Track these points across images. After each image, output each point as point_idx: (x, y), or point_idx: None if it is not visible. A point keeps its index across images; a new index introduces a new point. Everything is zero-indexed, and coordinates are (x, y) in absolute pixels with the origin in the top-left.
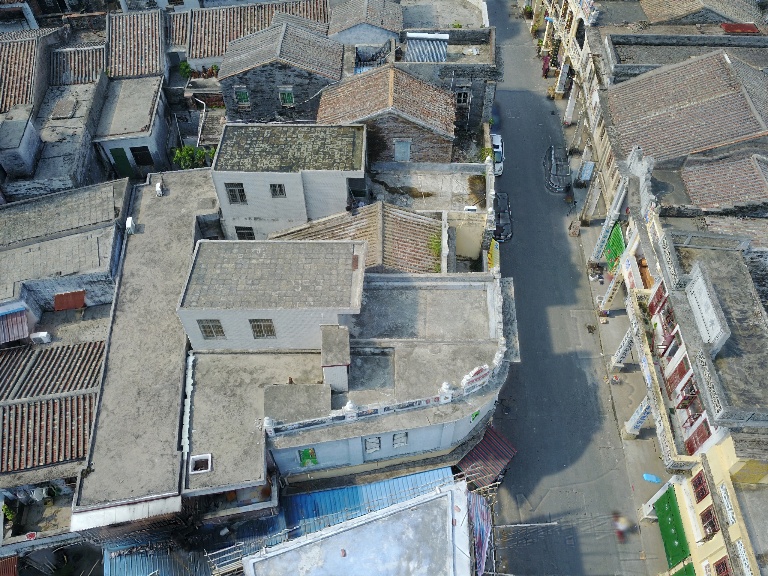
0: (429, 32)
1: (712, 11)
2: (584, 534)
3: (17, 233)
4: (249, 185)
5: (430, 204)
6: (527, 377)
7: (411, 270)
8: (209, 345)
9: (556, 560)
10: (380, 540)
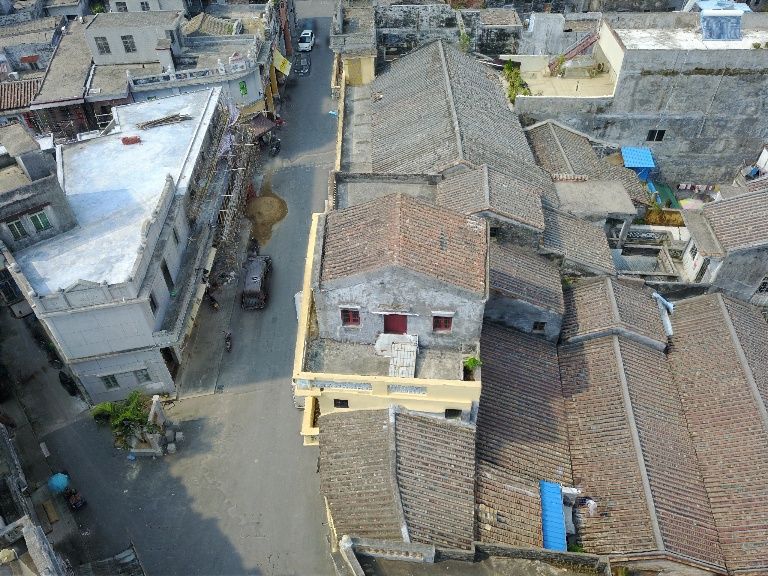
0: None
1: None
2: (316, 168)
3: (0, 33)
4: (129, 3)
5: None
6: (302, 122)
7: (215, 35)
8: (103, 60)
9: (298, 176)
10: (176, 100)
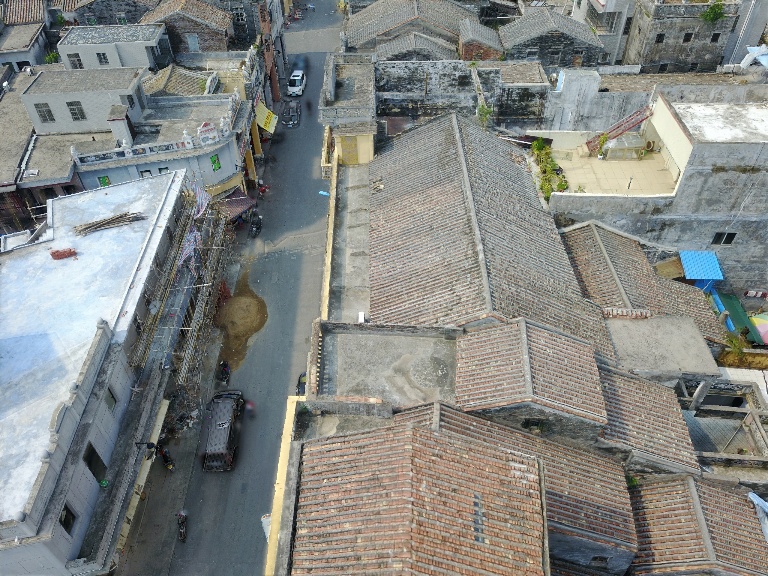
0: None
1: None
2: (304, 254)
3: None
4: (83, 55)
5: None
6: (289, 190)
7: None
8: (46, 129)
9: (282, 266)
10: (128, 189)
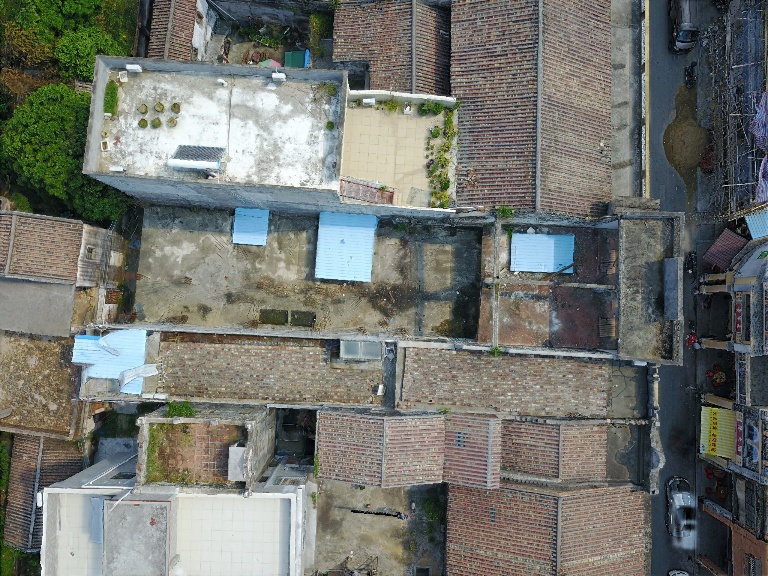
0: None
1: None
2: None
3: None
4: None
5: None
6: None
7: None
8: None
9: None
10: None
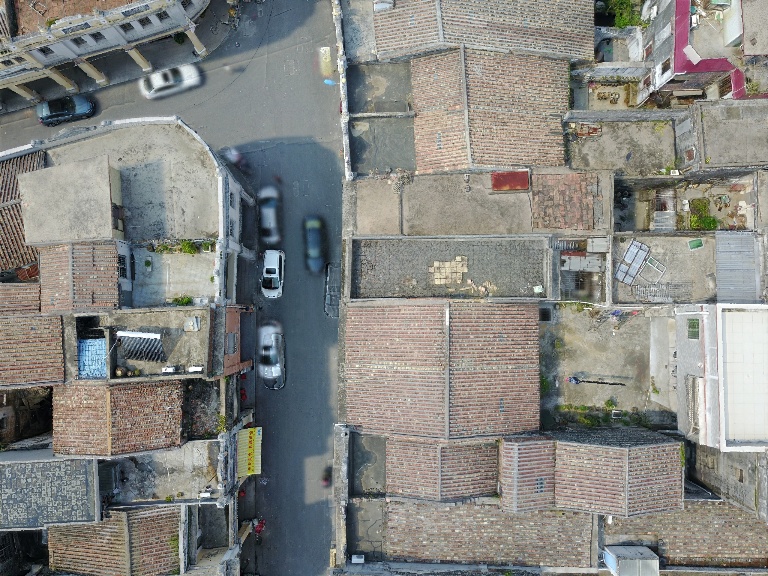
0: (144, 312)
1: (479, 169)
2: None
3: None
4: None
5: (174, 483)
6: (288, 527)
7: (157, 573)
8: None
9: None
10: None
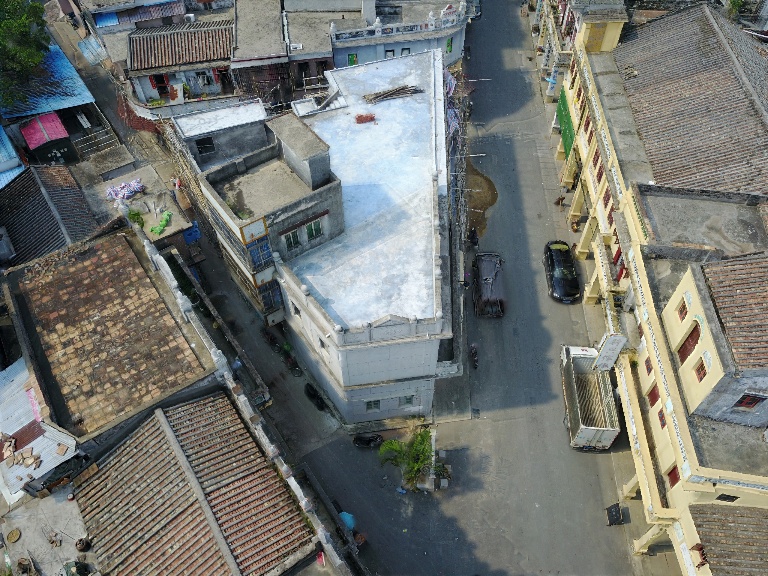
0: None
1: None
2: (517, 140)
3: None
4: None
5: None
6: None
7: None
8: (295, 6)
9: (499, 149)
10: (396, 65)
